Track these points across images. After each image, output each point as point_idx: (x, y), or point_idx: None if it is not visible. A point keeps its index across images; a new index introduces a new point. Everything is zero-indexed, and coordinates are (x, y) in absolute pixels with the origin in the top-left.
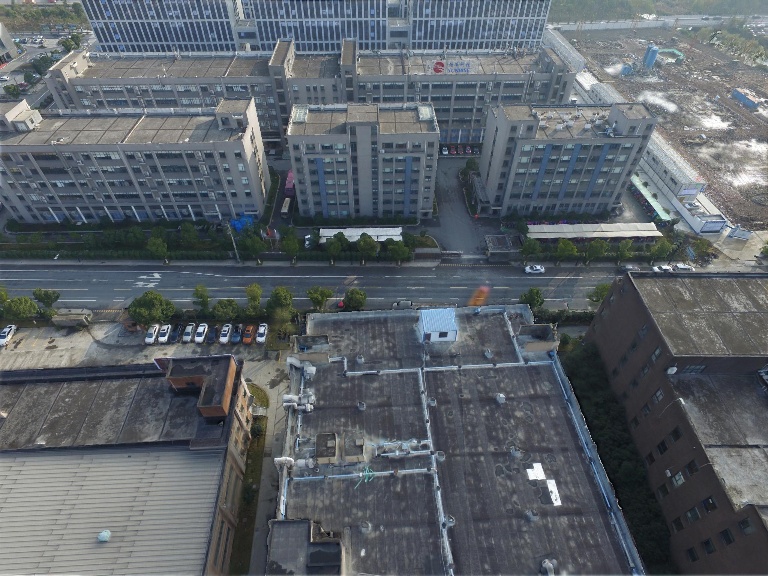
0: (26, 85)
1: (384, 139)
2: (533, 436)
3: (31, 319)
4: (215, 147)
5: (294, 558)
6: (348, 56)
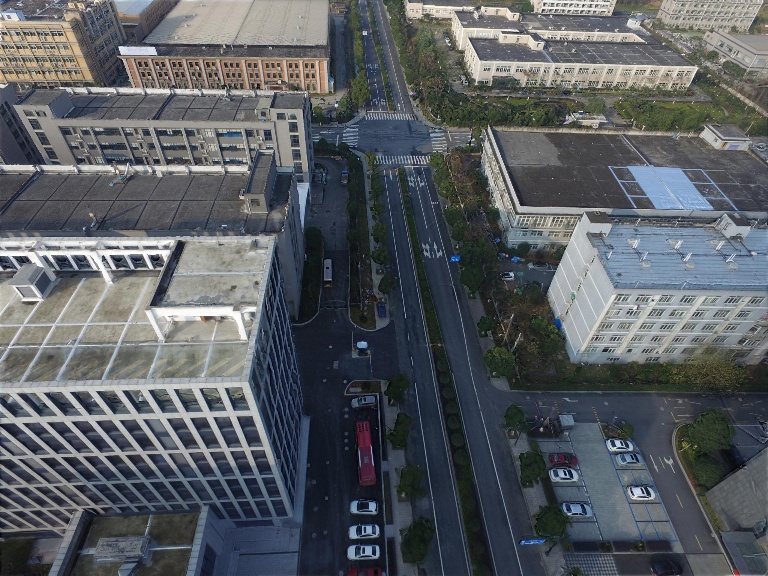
0: (552, 456)
1: None
2: (12, 7)
3: None
4: (85, 93)
5: None
6: None
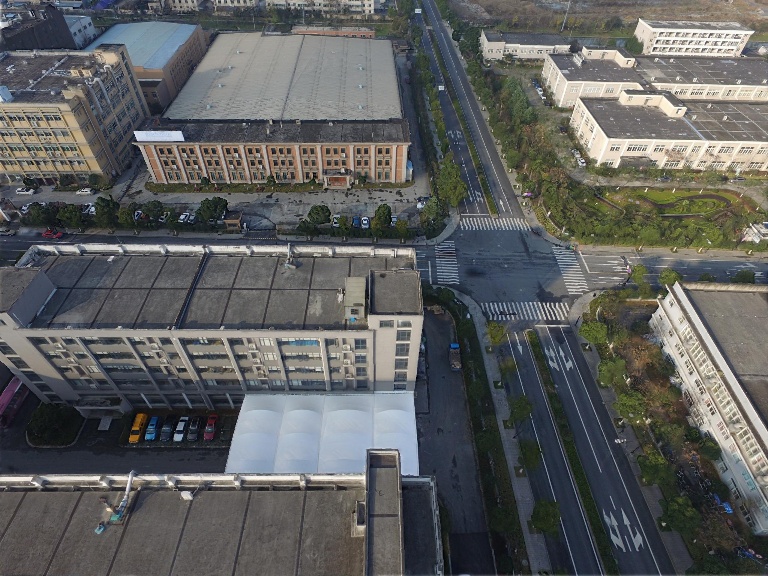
0: None
1: None
2: None
3: (324, 231)
4: None
5: (111, 49)
6: None
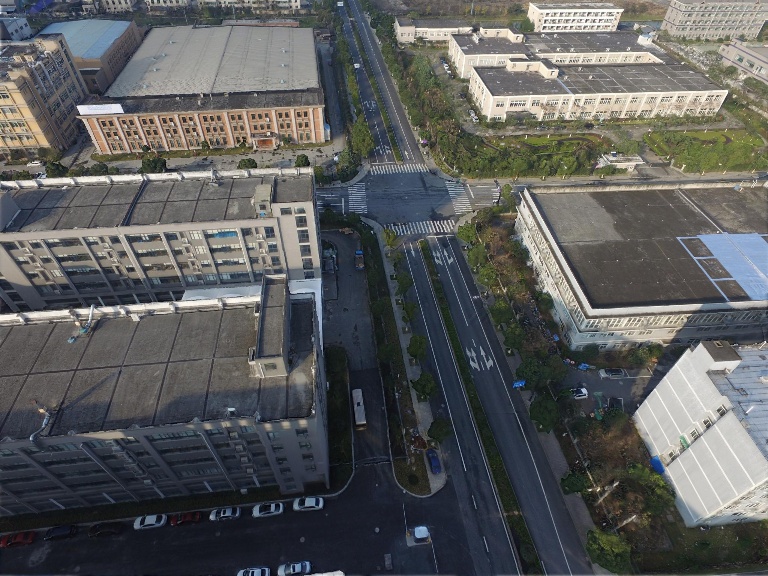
0: None
1: None
2: None
3: None
4: (35, 186)
5: None
6: None
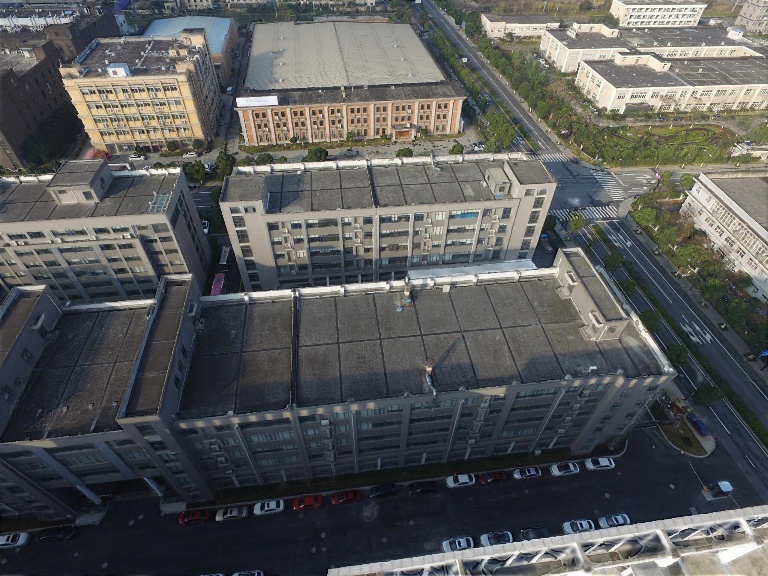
0: None
1: None
2: None
3: None
4: (267, 171)
5: None
6: (8, 333)
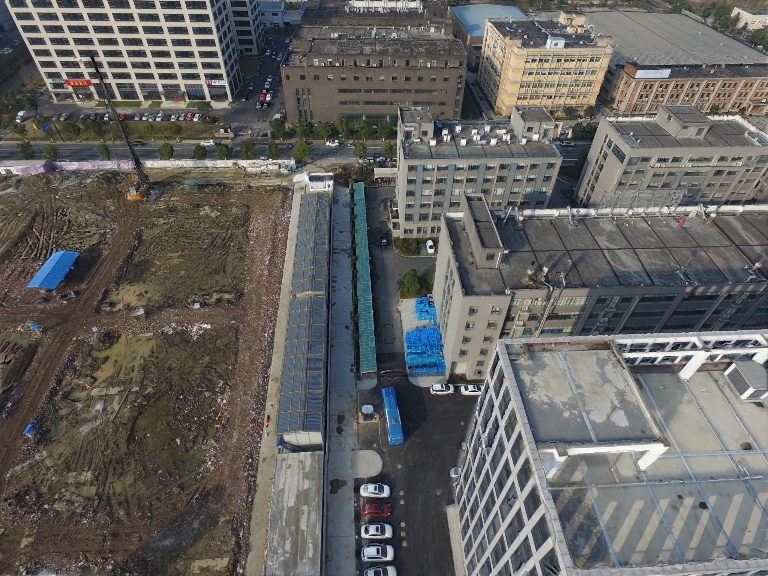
0: None
1: (650, 121)
2: None
3: None
4: None
5: (576, 14)
6: None
